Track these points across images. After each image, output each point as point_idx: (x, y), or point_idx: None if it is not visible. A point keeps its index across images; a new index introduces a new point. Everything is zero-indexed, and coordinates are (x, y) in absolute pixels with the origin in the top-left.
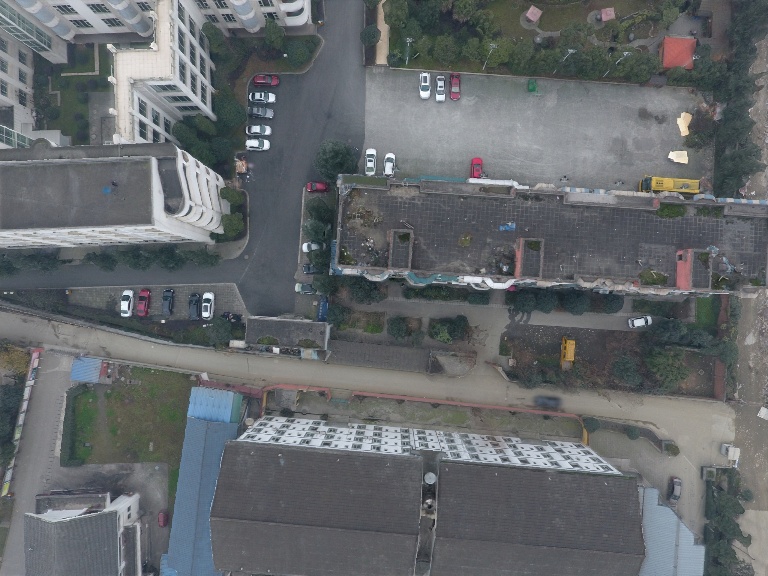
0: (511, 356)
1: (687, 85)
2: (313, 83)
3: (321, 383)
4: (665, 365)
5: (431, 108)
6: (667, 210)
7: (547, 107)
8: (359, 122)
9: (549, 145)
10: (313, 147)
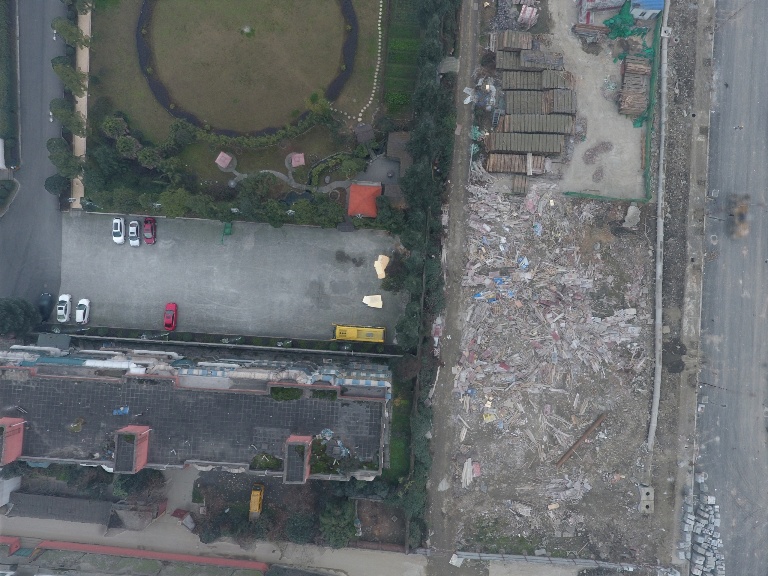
0: (204, 503)
1: (382, 229)
2: (9, 228)
3: (12, 532)
4: (330, 525)
5: (128, 252)
6: (281, 393)
7: (244, 250)
8: (55, 267)
9: (246, 289)
10: (8, 293)
